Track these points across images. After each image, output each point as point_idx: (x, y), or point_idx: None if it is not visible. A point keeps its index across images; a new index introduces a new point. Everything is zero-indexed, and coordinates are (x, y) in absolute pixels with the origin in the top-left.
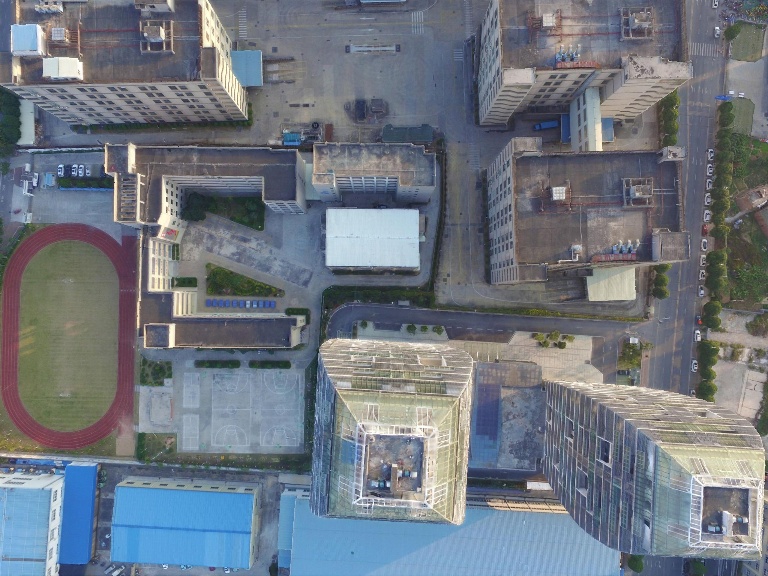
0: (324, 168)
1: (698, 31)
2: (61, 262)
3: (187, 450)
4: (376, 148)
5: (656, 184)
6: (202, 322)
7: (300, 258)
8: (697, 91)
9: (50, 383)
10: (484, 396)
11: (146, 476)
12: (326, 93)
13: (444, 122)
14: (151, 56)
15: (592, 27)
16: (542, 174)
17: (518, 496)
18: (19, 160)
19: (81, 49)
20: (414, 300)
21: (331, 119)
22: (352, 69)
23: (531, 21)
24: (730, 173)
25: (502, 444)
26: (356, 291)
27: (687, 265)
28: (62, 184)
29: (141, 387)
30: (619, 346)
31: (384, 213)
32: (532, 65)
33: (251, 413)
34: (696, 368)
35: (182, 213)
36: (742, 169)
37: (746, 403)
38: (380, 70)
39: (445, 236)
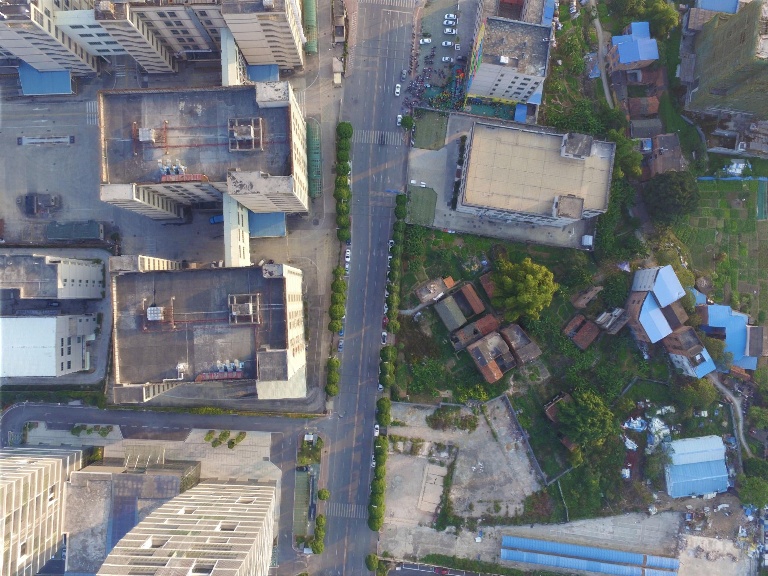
0: None
1: (381, 119)
2: None
3: None
4: None
5: (265, 299)
6: None
7: None
8: (379, 181)
9: None
10: (119, 508)
11: None
12: None
13: (119, 215)
14: None
15: (200, 138)
16: (148, 291)
17: None
18: None
19: None
20: None
21: (2, 214)
22: (24, 162)
23: (134, 134)
24: (396, 269)
25: None
26: (19, 393)
27: (367, 358)
28: None
29: None
30: (298, 442)
31: (19, 322)
32: (139, 178)
33: None
34: (374, 463)
35: None
36: (416, 262)
37: (426, 497)
38: (53, 162)
39: None
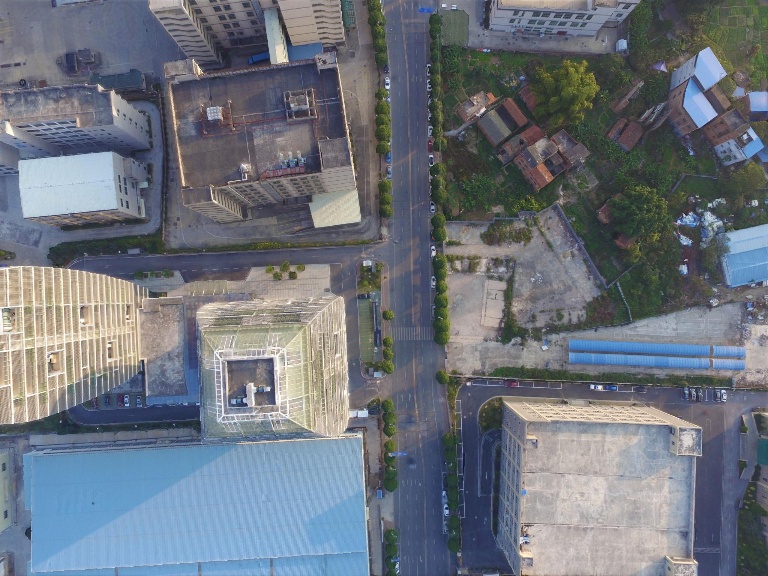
0: (1, 118)
1: None
2: None
3: None
4: (52, 93)
5: (319, 95)
6: None
7: None
8: (410, 8)
9: None
10: (193, 330)
11: None
12: (37, 50)
13: (159, 66)
14: None
15: None
16: (204, 97)
17: None
18: None
19: None
20: (145, 248)
21: (44, 76)
22: (61, 23)
23: None
24: (438, 84)
25: None
26: (79, 244)
27: (417, 183)
28: None
29: None
30: (357, 271)
31: (77, 159)
32: None
33: None
34: (434, 284)
35: None
36: (456, 80)
37: (488, 313)
38: (89, 21)
39: (171, 180)
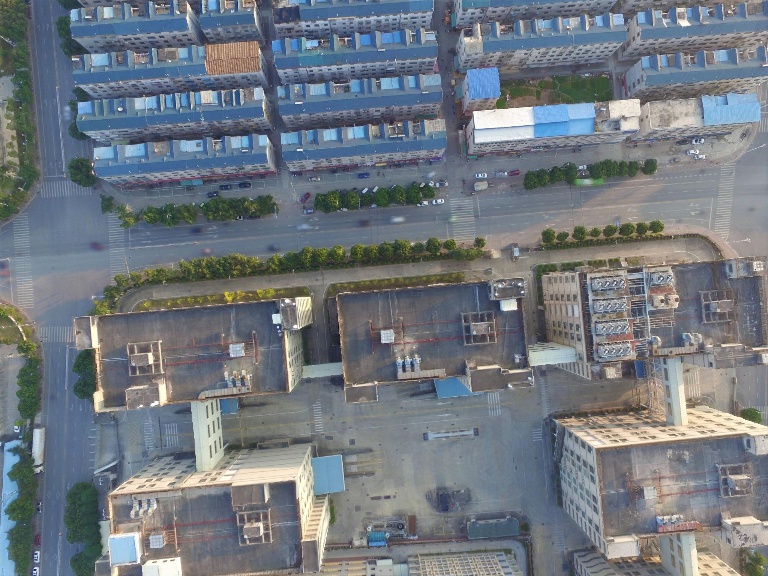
0: None
1: None
2: None
3: None
4: None
5: None
6: None
7: None
8: None
9: None
10: None
11: None
12: (407, 483)
13: (527, 505)
14: (249, 545)
15: (690, 485)
16: None
17: None
18: None
19: (178, 545)
20: None
21: (413, 509)
22: (431, 456)
23: (631, 487)
24: None
25: None
26: None
27: None
28: None
29: None
30: None
31: None
32: (633, 527)
33: None
34: None
35: None
36: None
37: None
38: (459, 456)
39: None
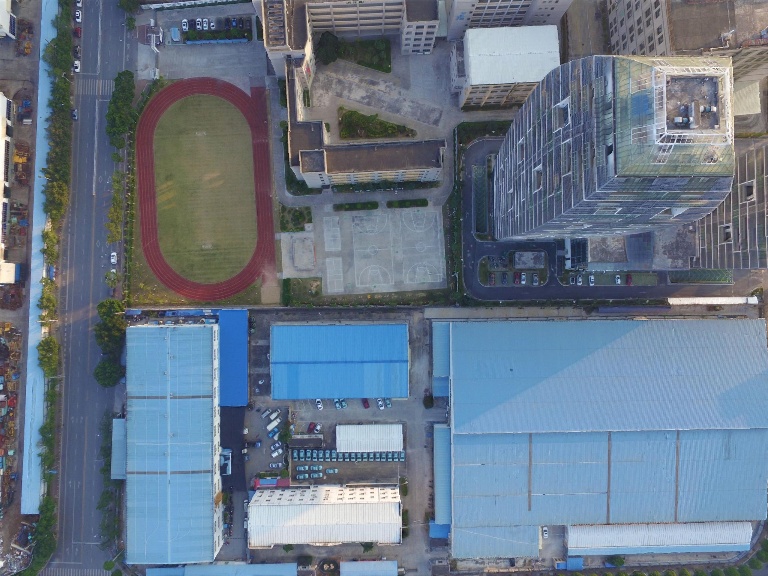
0: None
1: None
2: (192, 117)
3: (332, 293)
4: None
5: None
6: (352, 149)
7: (429, 98)
8: None
9: (191, 237)
10: None
11: (294, 321)
12: None
13: None
14: None
15: None
16: None
17: (658, 315)
18: (141, 18)
19: None
20: None
21: None
22: None
23: None
24: None
25: (655, 246)
26: None
27: None
28: (191, 35)
29: (282, 234)
30: None
31: (523, 30)
32: None
33: (392, 252)
34: None
35: (315, 53)
36: None
37: None
38: None
39: None
